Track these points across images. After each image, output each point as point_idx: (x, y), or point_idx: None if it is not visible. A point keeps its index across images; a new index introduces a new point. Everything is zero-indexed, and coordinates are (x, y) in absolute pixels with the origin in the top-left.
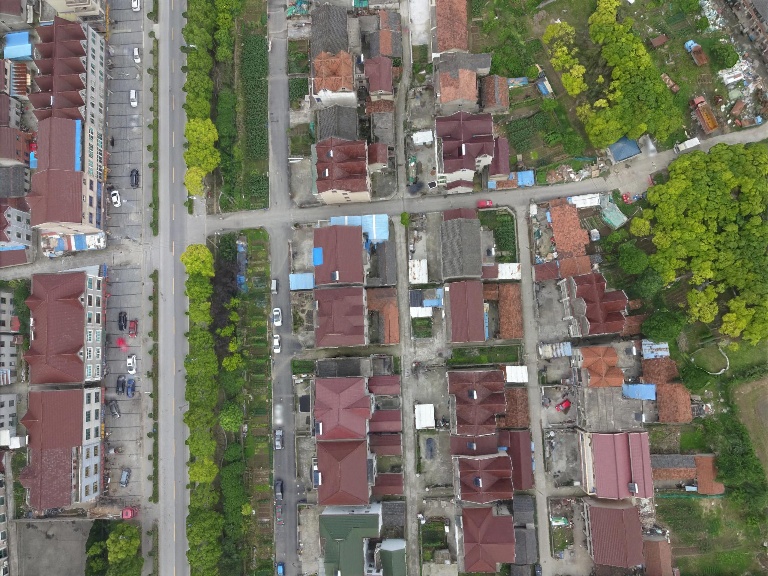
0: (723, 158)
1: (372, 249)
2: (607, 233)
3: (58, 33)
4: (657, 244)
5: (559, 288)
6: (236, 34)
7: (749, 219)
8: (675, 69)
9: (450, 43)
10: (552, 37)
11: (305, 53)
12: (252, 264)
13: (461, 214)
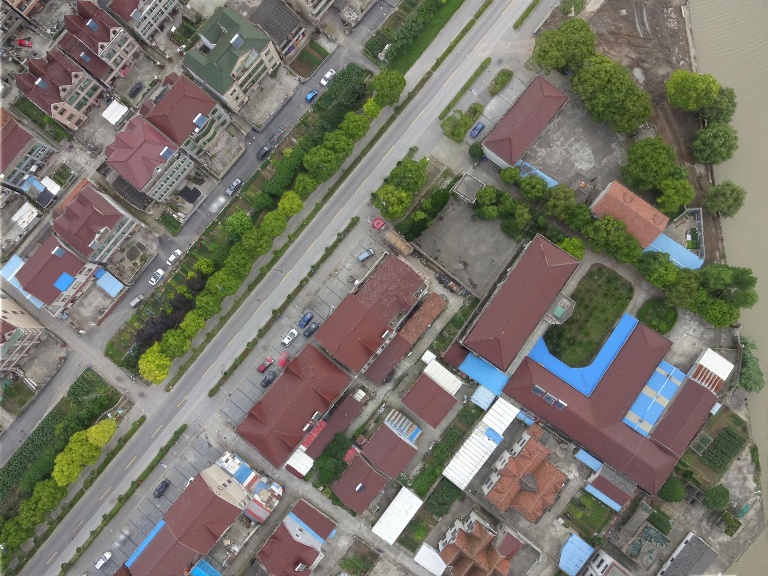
0: None
1: None
2: None
3: None
4: None
5: None
6: None
7: None
8: None
9: None
10: None
11: None
12: None
13: None
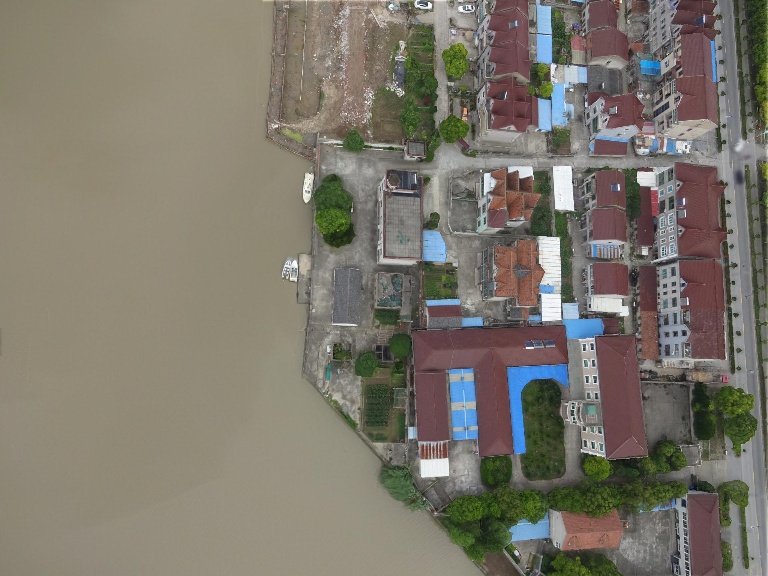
0: None
1: None
2: None
3: None
4: None
5: None
6: None
7: None
8: None
9: None
10: None
11: None
12: None
13: None
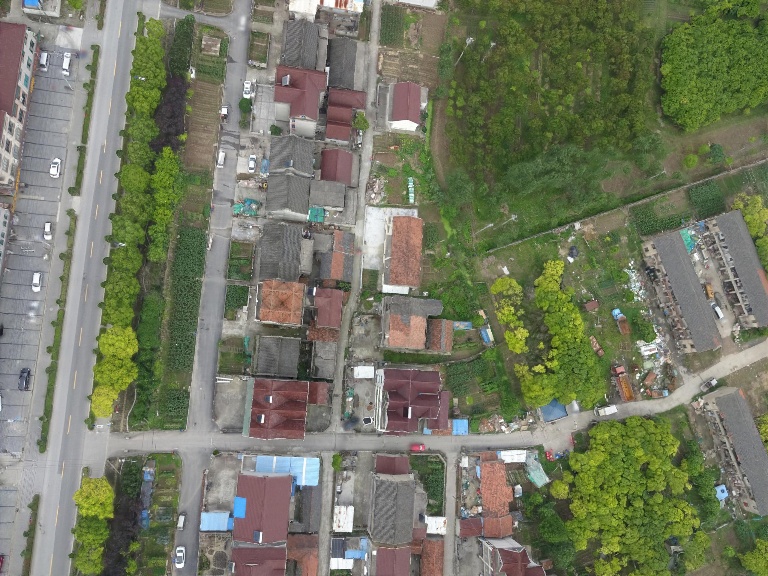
0: (637, 435)
1: (296, 486)
2: (528, 488)
3: None
4: (574, 513)
5: (479, 542)
6: (174, 230)
7: (653, 495)
8: (602, 332)
9: (403, 279)
10: (500, 292)
11: (249, 258)
12: (158, 493)
13: (395, 464)
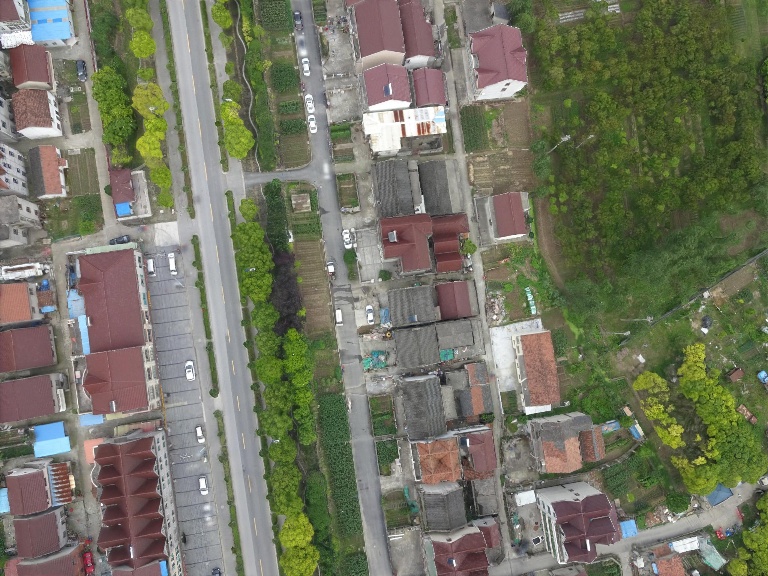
0: None
1: None
2: (704, 569)
3: (125, 464)
4: None
5: None
6: (316, 407)
7: None
8: (750, 398)
9: (544, 399)
10: (645, 389)
11: (389, 411)
12: None
13: None
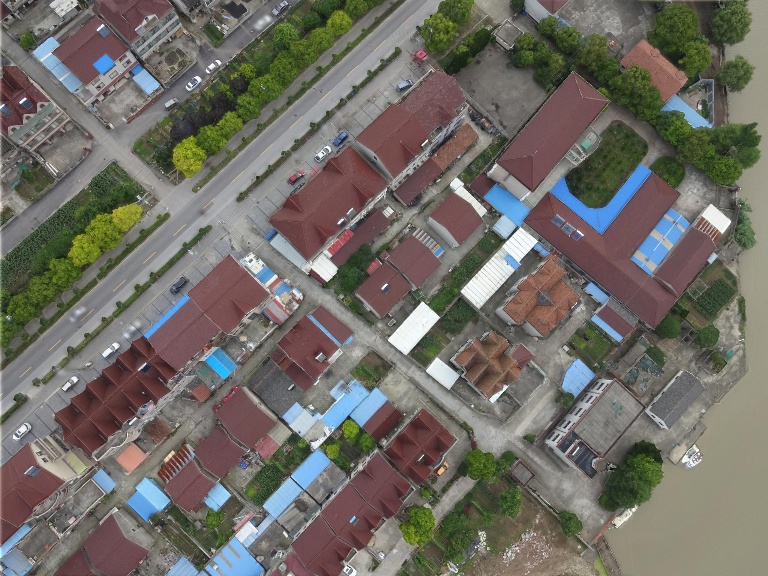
0: None
1: None
2: None
3: None
4: None
5: None
6: None
7: None
8: None
9: None
10: None
11: None
12: None
13: None
